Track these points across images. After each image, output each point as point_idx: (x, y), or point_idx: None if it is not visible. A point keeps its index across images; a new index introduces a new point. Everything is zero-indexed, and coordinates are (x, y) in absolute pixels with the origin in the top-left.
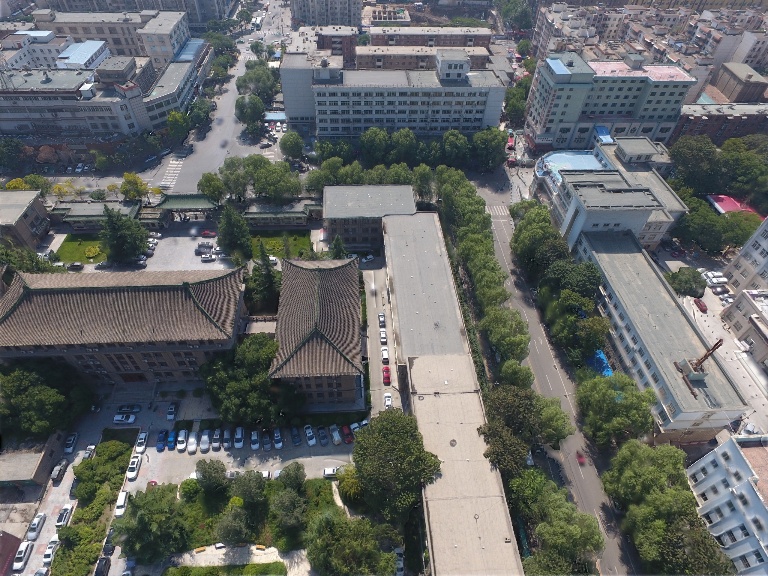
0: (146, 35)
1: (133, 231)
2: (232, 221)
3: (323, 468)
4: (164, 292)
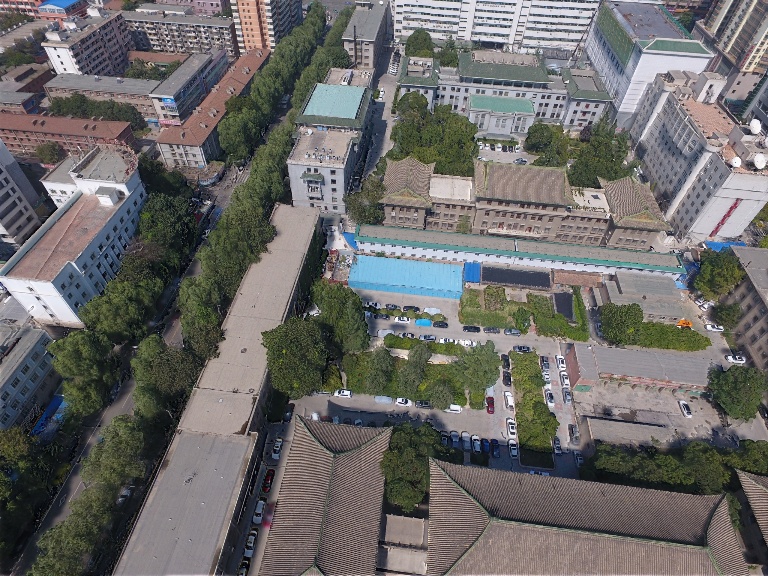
0: None
1: None
2: None
3: (352, 400)
4: (522, 519)
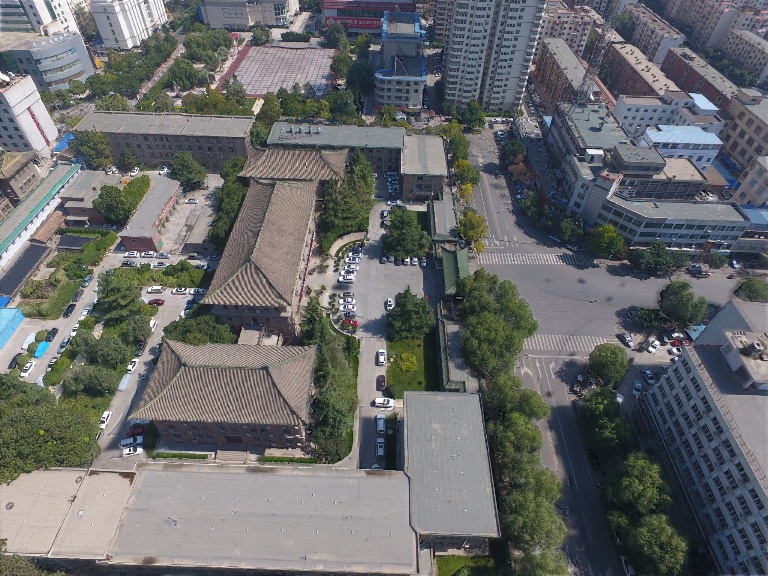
0: (760, 166)
1: (407, 240)
2: (400, 301)
3: (115, 412)
4: None
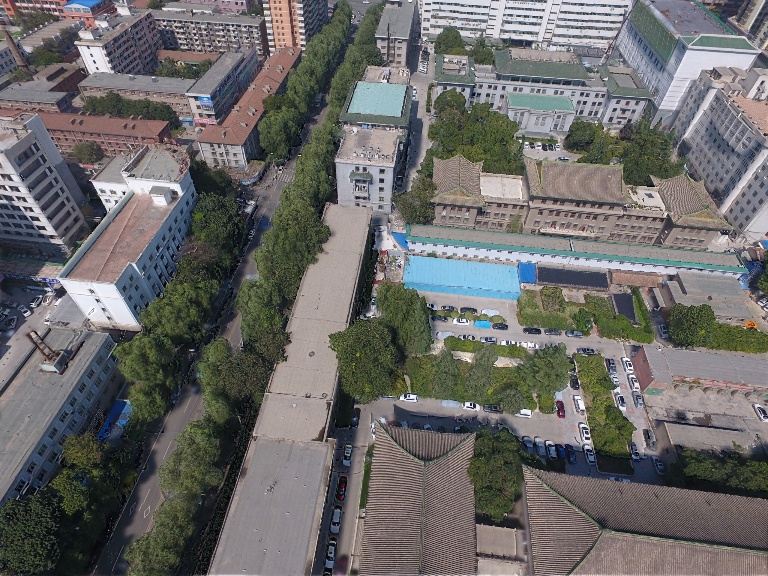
0: None
1: None
2: None
3: (418, 405)
4: (633, 530)
